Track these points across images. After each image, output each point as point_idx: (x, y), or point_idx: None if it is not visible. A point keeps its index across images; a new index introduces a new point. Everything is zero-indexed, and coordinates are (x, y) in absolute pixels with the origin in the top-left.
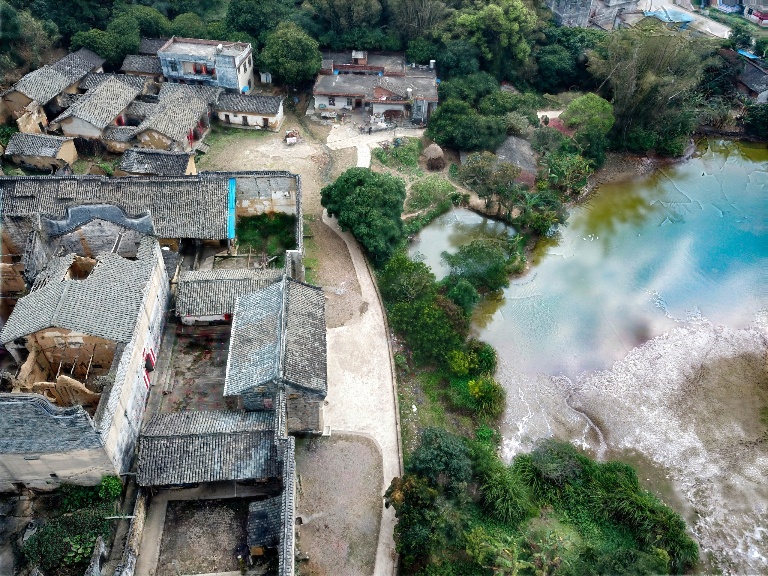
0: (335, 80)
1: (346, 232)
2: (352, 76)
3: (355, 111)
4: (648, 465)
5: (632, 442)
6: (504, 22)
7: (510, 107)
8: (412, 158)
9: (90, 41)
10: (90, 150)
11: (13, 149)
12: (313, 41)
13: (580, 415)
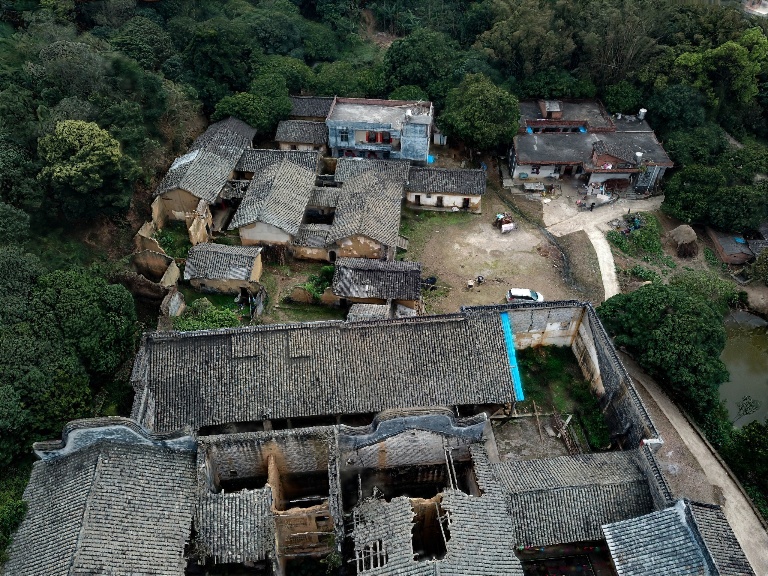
0: (534, 142)
1: (635, 367)
2: (552, 135)
3: (564, 180)
4: None
5: None
6: (748, 63)
7: (766, 171)
8: (656, 243)
9: (239, 109)
10: (273, 258)
11: (193, 271)
12: (513, 97)
13: None
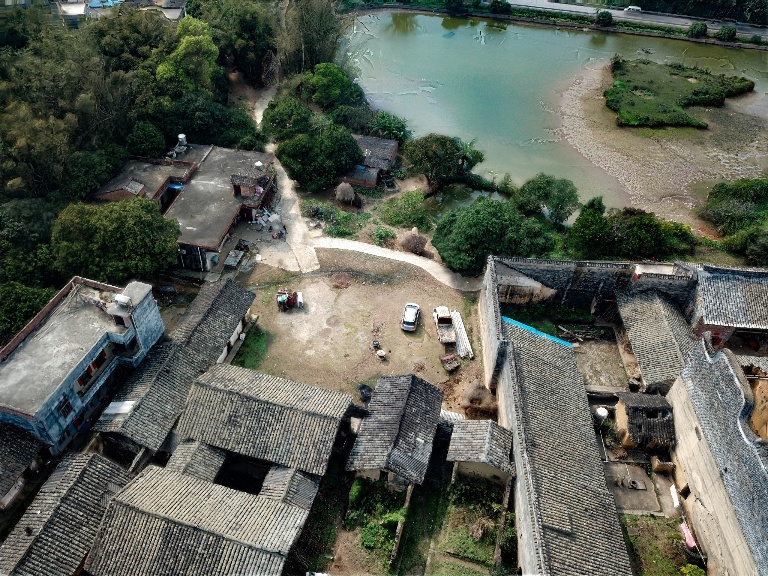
0: None
1: None
2: (174, 209)
3: (237, 232)
4: (696, 185)
5: (680, 186)
6: None
7: None
8: None
9: None
10: (296, 575)
11: None
12: None
13: (665, 200)
